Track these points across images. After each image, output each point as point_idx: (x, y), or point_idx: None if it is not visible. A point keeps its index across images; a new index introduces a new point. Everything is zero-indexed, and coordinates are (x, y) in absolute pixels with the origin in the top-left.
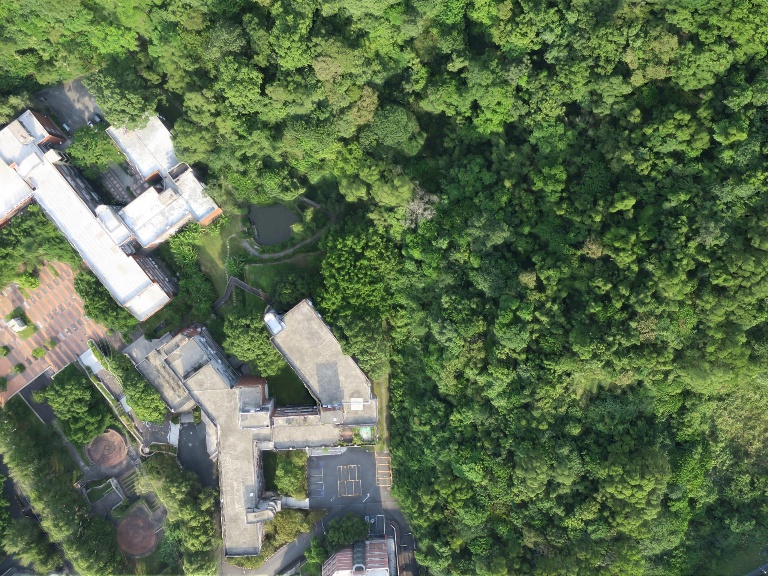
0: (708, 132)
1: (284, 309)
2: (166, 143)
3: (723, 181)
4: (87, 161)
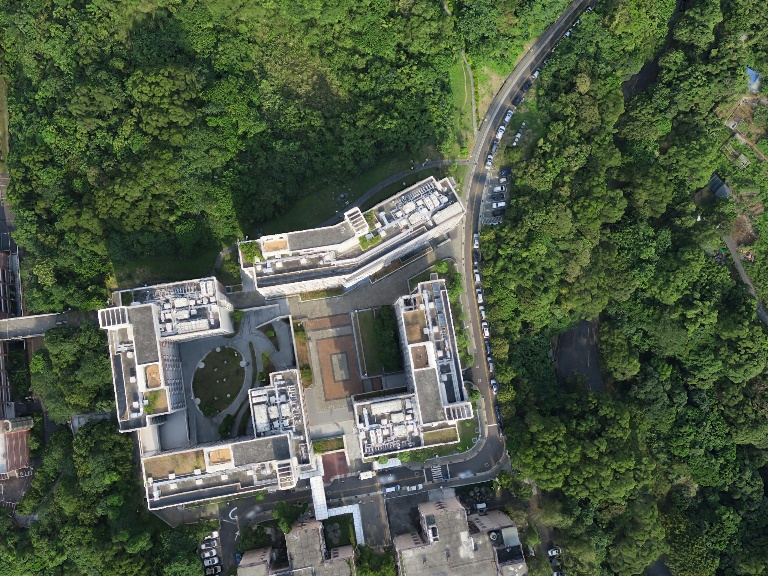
0: None
1: None
2: None
3: None
4: None
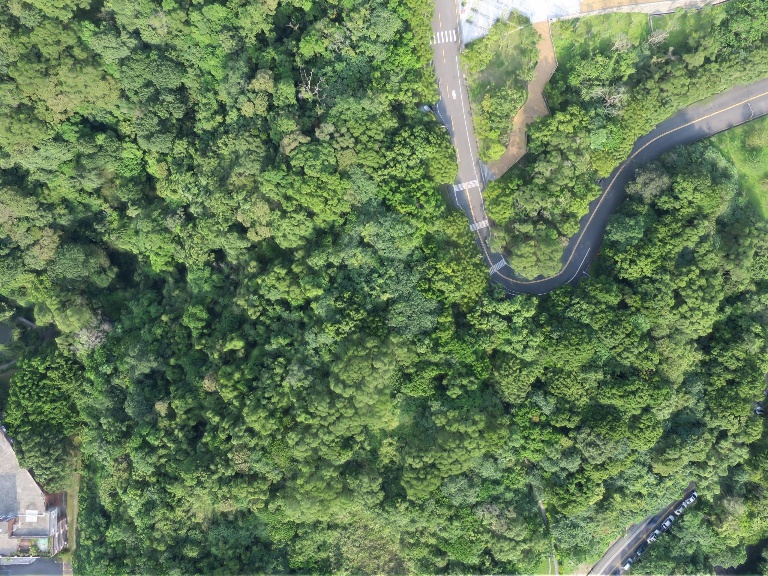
0: (297, 285)
1: None
2: None
3: (309, 329)
4: None
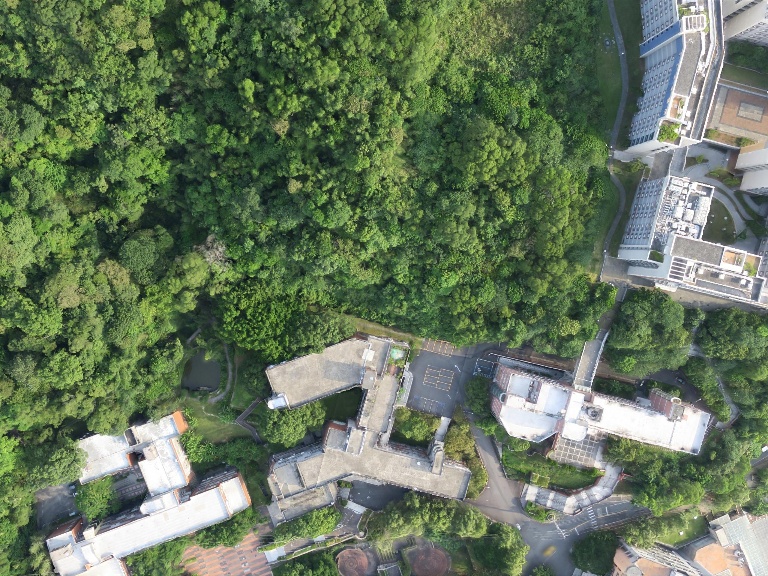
0: (204, 2)
1: (269, 390)
2: (106, 440)
3: (250, 2)
4: (105, 507)
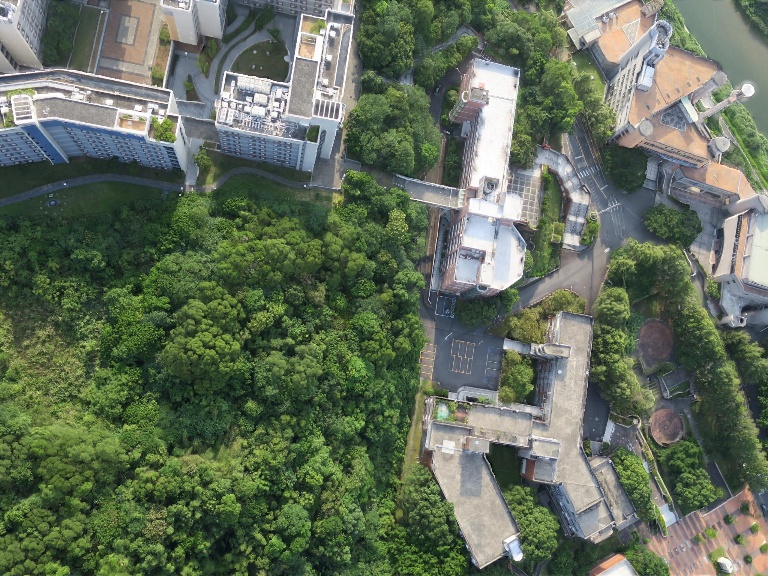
0: None
1: None
2: None
3: None
4: None
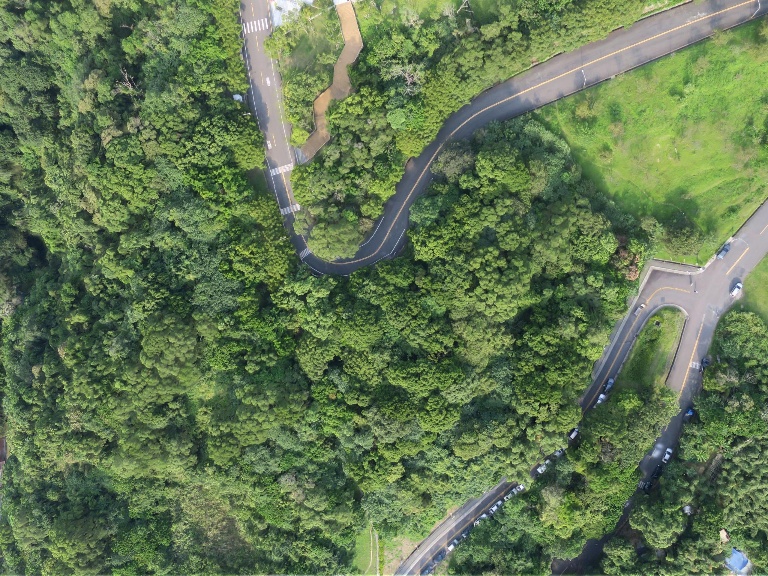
0: None
1: None
2: None
3: (128, 306)
4: None
